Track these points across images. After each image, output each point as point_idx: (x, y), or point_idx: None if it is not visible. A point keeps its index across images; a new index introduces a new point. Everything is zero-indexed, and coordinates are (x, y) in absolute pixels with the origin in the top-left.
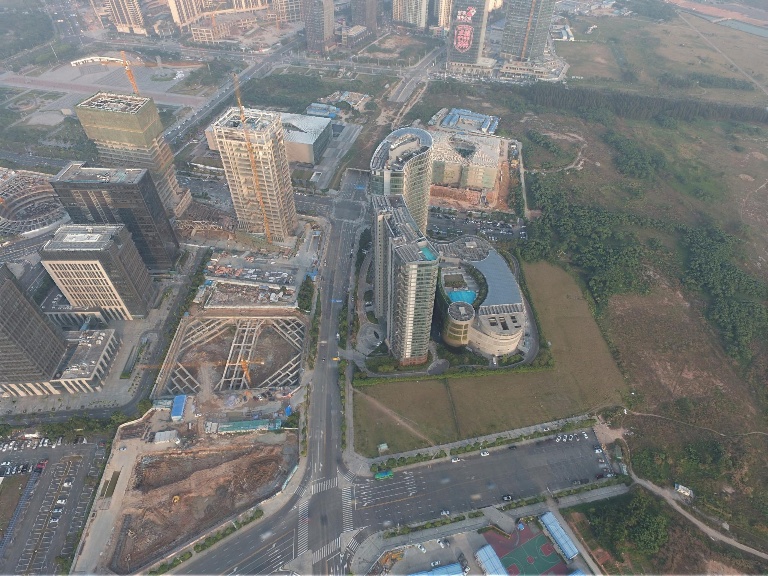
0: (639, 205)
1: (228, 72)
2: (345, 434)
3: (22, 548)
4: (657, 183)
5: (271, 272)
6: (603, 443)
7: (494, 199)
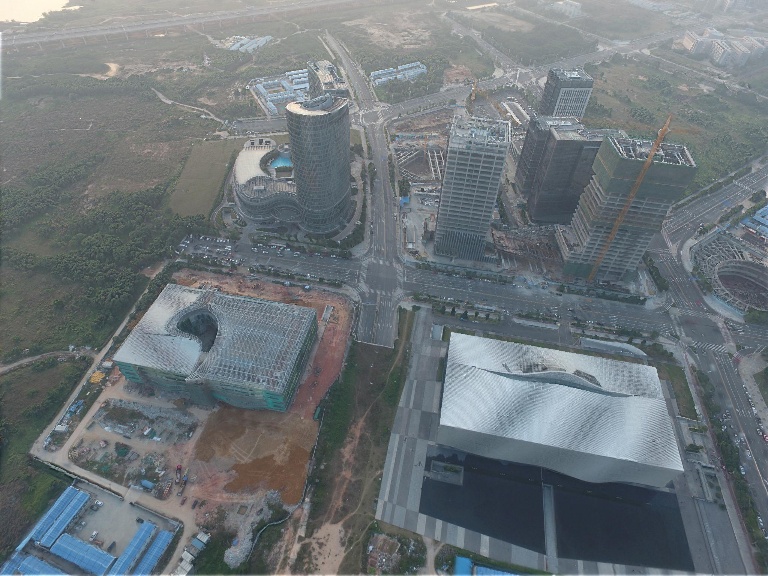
0: None
1: None
2: None
3: (490, 113)
4: None
5: None
6: None
7: None
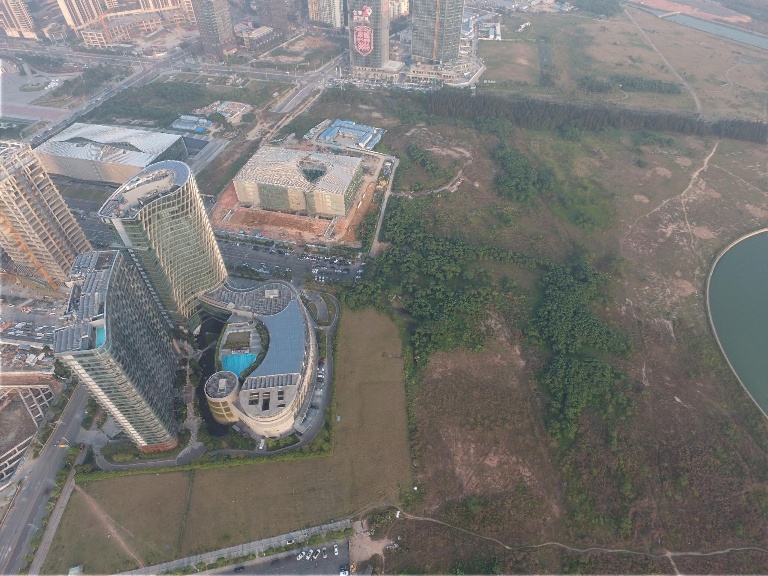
0: (507, 235)
1: (108, 80)
2: (36, 552)
3: None
4: (536, 207)
5: (43, 326)
6: (355, 561)
7: (343, 229)
